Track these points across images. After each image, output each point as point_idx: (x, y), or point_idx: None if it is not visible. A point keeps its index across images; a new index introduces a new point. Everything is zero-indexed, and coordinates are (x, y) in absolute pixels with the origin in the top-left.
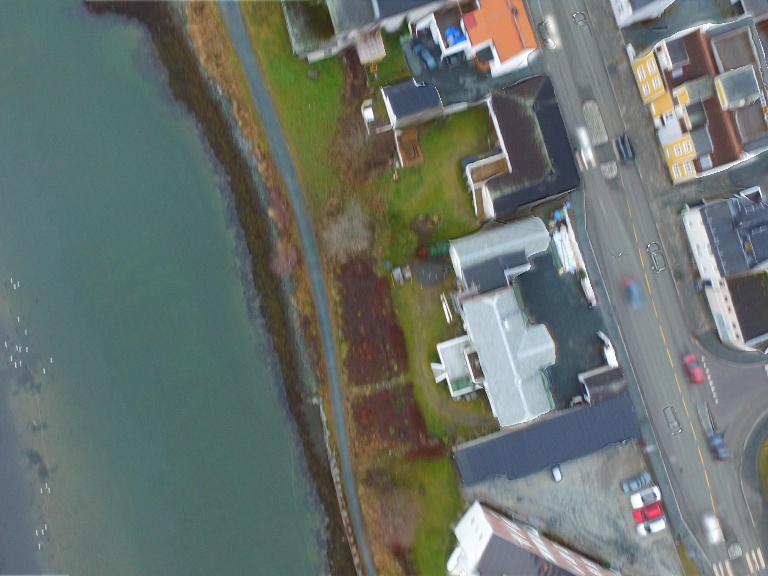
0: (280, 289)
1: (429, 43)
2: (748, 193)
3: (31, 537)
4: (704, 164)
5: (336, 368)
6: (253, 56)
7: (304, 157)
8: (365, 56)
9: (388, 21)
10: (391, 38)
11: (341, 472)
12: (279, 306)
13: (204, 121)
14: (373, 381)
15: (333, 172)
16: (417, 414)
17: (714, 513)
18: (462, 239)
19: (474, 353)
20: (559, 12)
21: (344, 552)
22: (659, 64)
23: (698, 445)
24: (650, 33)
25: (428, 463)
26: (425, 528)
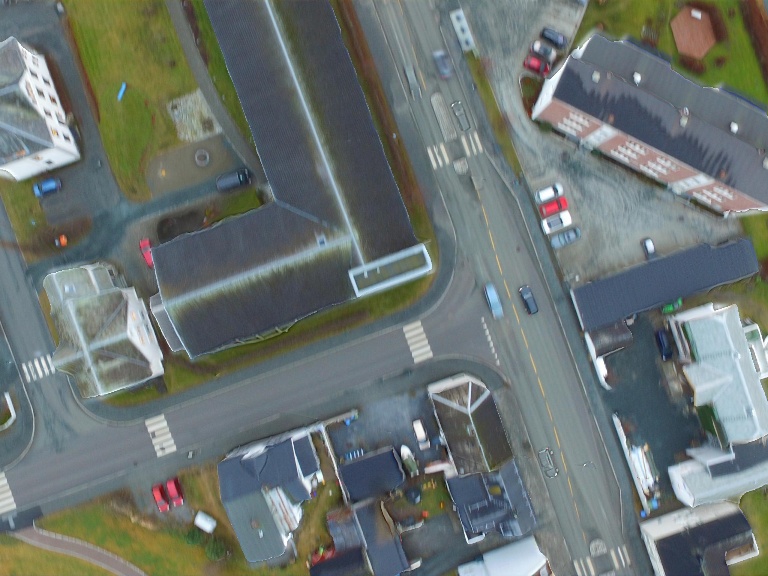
0: None
1: None
2: (480, 537)
3: None
4: (545, 571)
5: None
6: None
7: None
8: None
9: None
10: None
11: None
12: None
13: None
14: None
15: None
16: None
17: (484, 205)
18: None
19: None
20: None
21: None
22: None
23: (503, 275)
24: None
25: (767, 253)
26: None
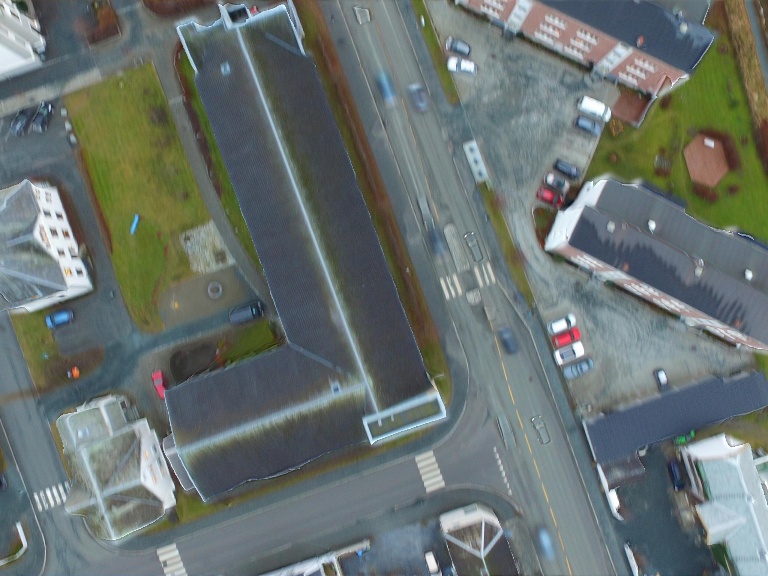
0: None
1: None
2: None
3: None
4: None
5: None
6: None
7: None
8: None
9: None
10: None
11: None
12: None
13: None
14: None
15: None
16: None
17: (497, 336)
18: None
19: None
20: None
21: None
22: None
23: (515, 406)
24: None
25: None
26: None
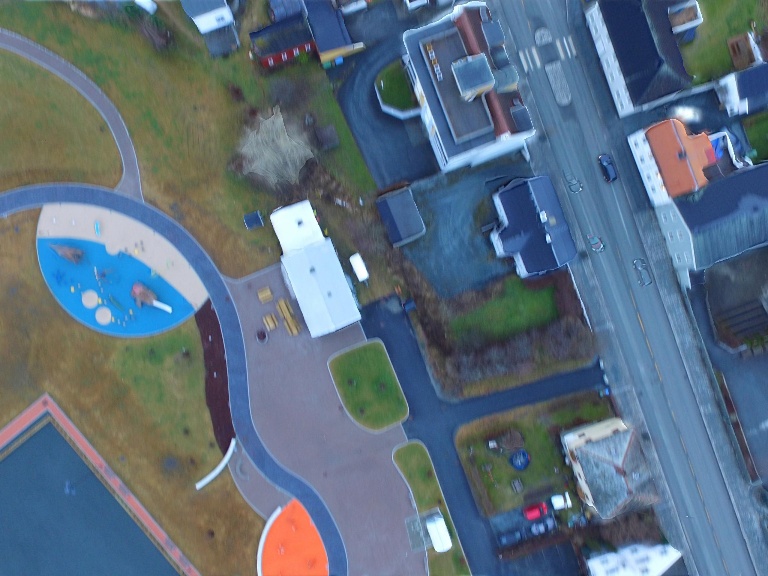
0: None
1: None
2: (421, 0)
3: None
4: (485, 14)
5: None
6: None
7: None
8: None
9: None
10: (764, 156)
11: None
12: None
13: None
14: None
15: None
16: None
17: None
18: None
19: None
20: (597, 192)
21: None
22: None
23: None
24: None
25: None
26: None
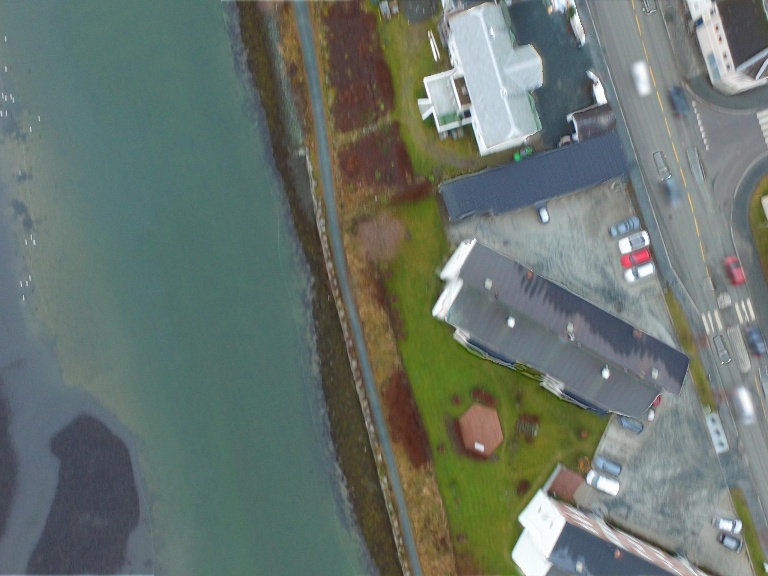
0: (267, 39)
1: None
2: None
3: (15, 288)
4: None
5: (323, 116)
6: None
7: None
8: None
9: None
10: None
11: (327, 223)
12: (266, 58)
13: None
14: (359, 126)
15: None
16: (403, 153)
17: (703, 261)
18: None
19: (460, 78)
20: None
21: (329, 311)
22: None
23: (688, 191)
24: None
25: (414, 206)
26: (411, 275)
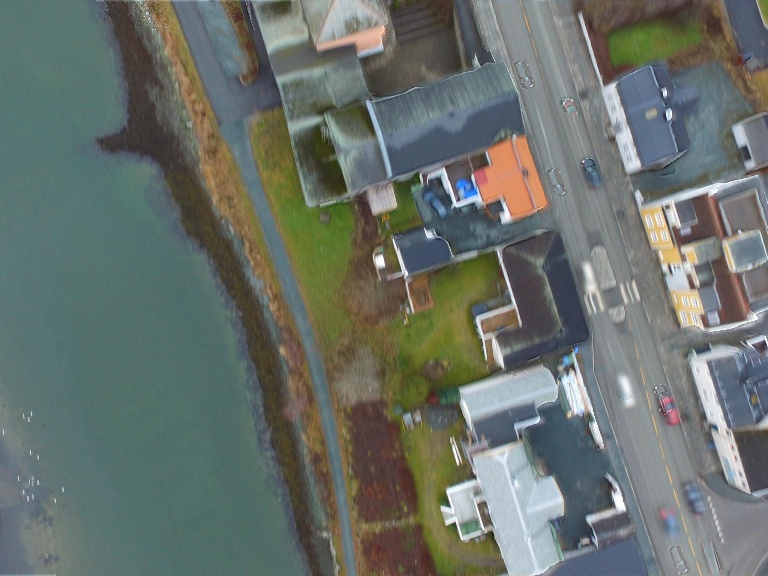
0: (291, 424)
1: (440, 191)
2: (754, 342)
3: None
4: (712, 320)
5: (346, 504)
6: (265, 200)
7: (315, 298)
8: (377, 208)
9: (400, 176)
10: (402, 187)
11: None
12: (289, 440)
13: (216, 257)
14: (383, 519)
15: (344, 312)
16: (426, 555)
17: None
18: (472, 391)
19: (484, 502)
20: (568, 158)
21: None
22: (667, 220)
23: None
24: (658, 179)
25: None
26: None
